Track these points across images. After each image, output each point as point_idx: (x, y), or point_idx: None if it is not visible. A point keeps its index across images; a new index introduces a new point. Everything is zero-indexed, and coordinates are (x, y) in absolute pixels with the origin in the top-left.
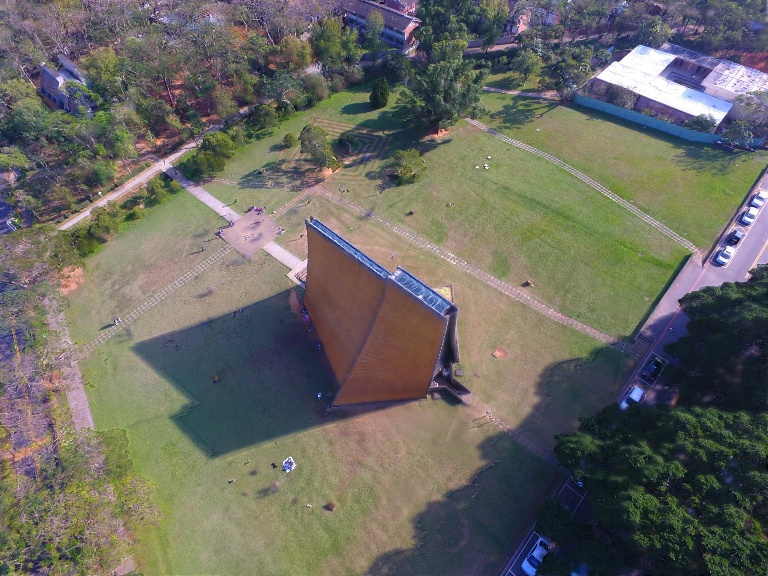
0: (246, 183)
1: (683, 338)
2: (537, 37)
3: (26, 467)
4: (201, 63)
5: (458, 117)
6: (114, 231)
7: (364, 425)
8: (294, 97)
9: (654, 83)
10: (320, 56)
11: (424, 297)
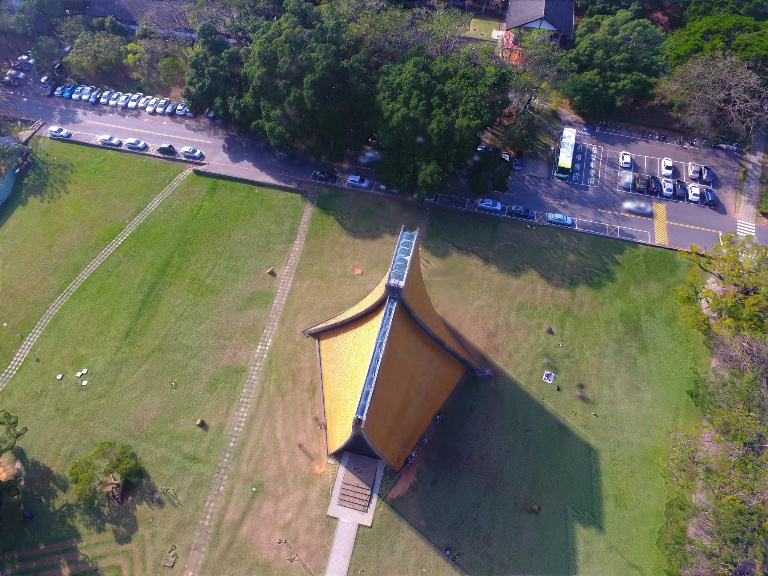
0: None
1: (307, 150)
2: None
3: None
4: None
5: (3, 411)
6: None
7: (480, 339)
8: None
9: None
10: None
11: None
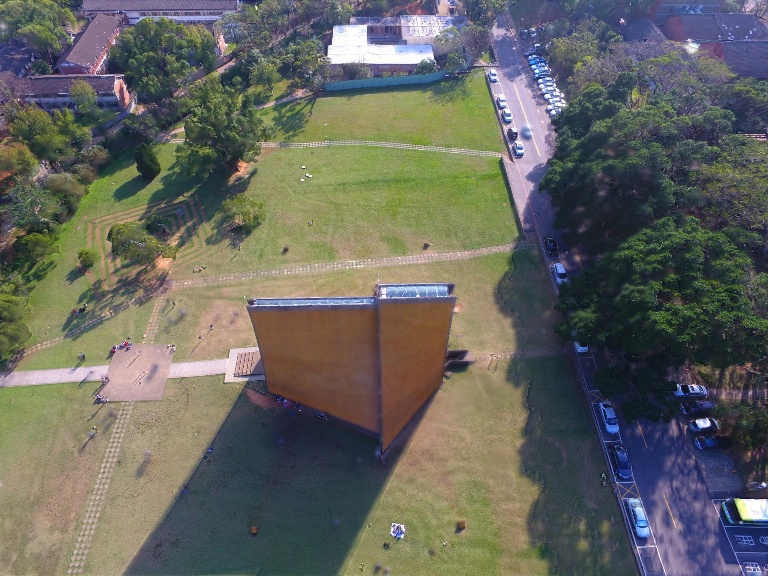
0: (76, 330)
1: (558, 212)
2: (253, 49)
3: None
4: None
5: (260, 144)
6: None
7: (421, 443)
8: (50, 211)
9: (370, 51)
10: (43, 154)
11: None
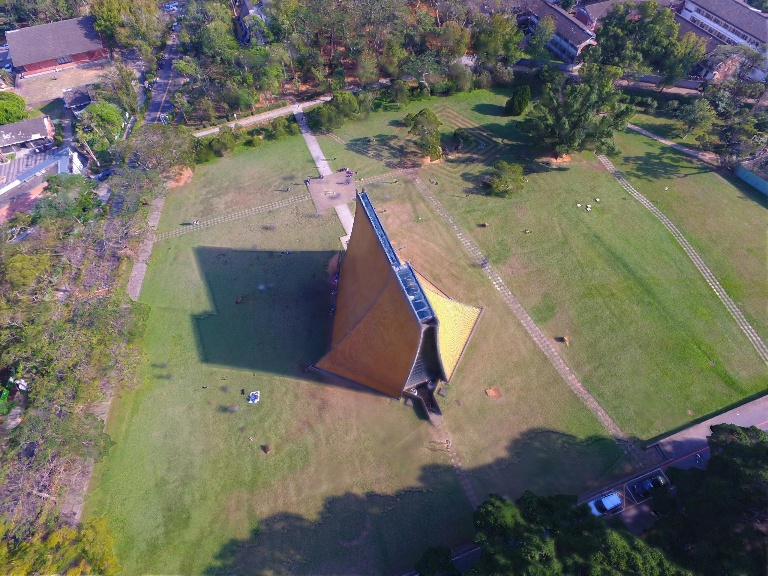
0: (353, 146)
1: (695, 469)
2: (725, 90)
3: (69, 301)
4: (362, 27)
5: (577, 146)
6: (230, 150)
7: (332, 396)
8: (433, 81)
9: None
10: (477, 49)
11: (417, 299)
